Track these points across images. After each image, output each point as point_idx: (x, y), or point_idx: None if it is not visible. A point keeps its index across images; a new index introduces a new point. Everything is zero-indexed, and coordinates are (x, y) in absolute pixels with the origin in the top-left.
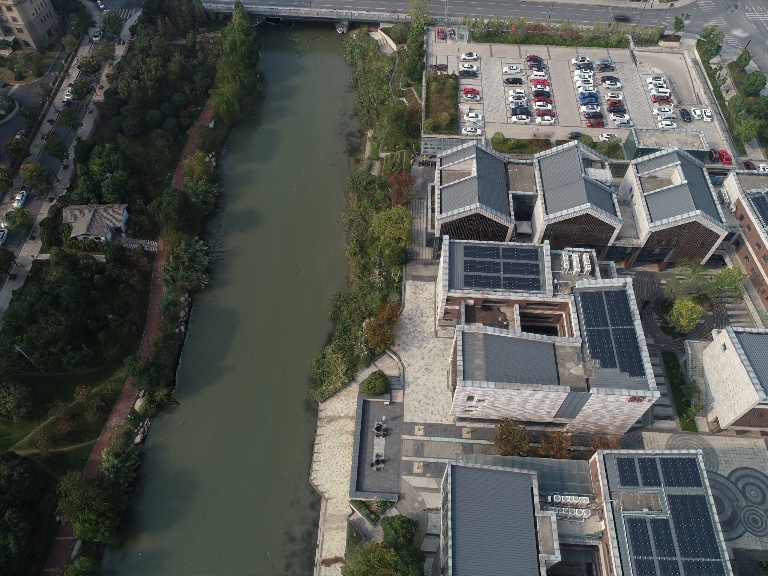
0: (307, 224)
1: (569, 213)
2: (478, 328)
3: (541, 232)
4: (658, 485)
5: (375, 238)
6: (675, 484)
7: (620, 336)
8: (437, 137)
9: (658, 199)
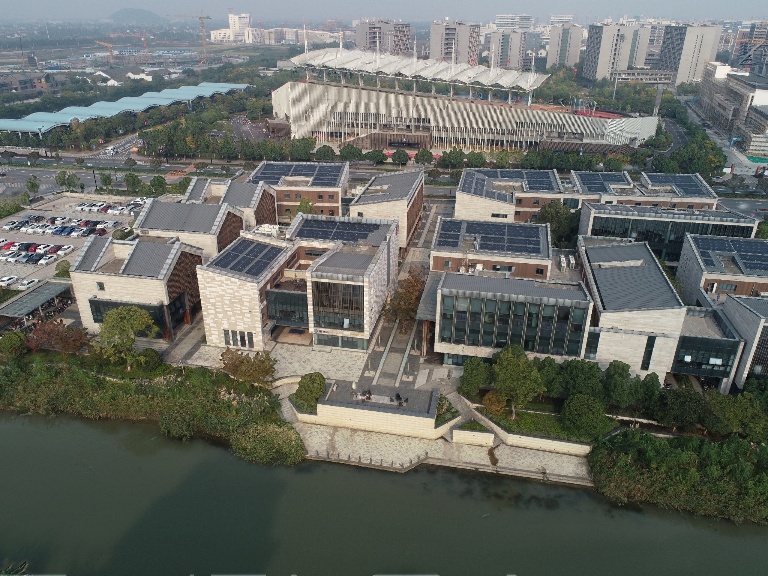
0: (4, 454)
1: (222, 217)
2: (314, 264)
3: (216, 249)
4: (459, 235)
5: (100, 384)
6: (459, 229)
7: (344, 228)
8: (8, 304)
9: (230, 199)
